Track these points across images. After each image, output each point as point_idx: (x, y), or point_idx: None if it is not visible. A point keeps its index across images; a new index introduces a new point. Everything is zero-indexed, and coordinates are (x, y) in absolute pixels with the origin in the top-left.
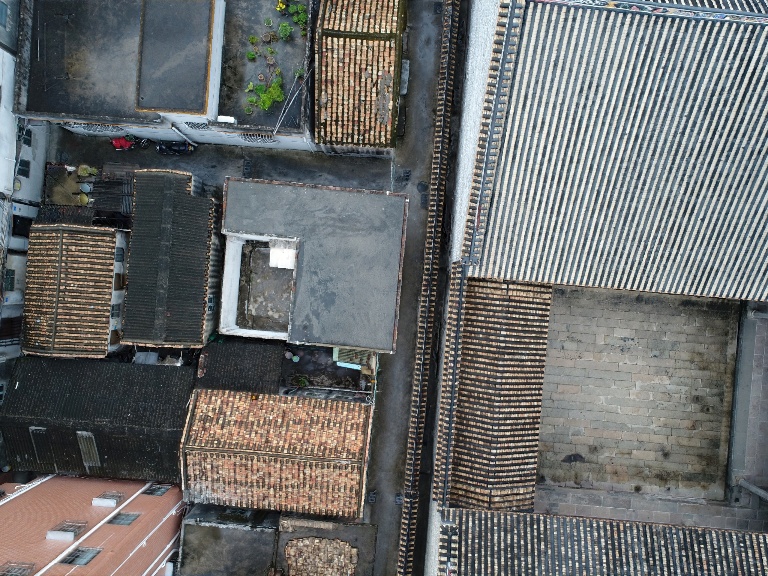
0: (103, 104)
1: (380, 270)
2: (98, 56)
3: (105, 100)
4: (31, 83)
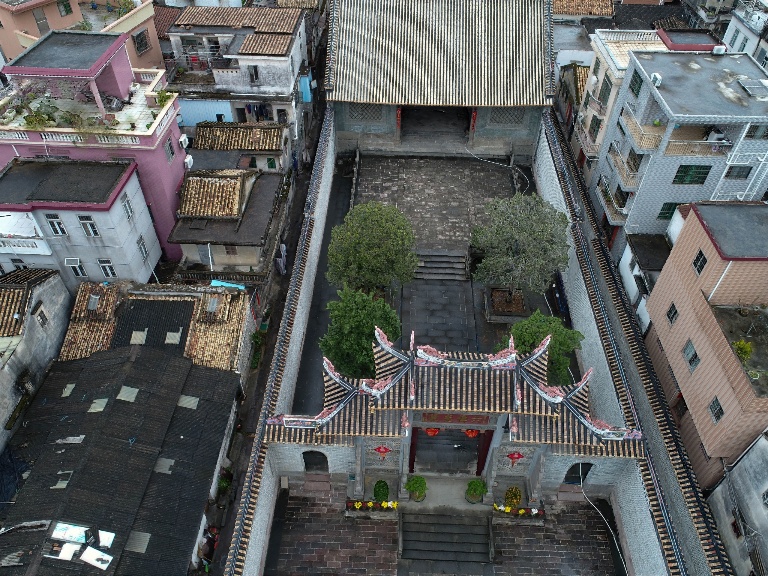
0: None
1: None
2: None
3: None
4: None
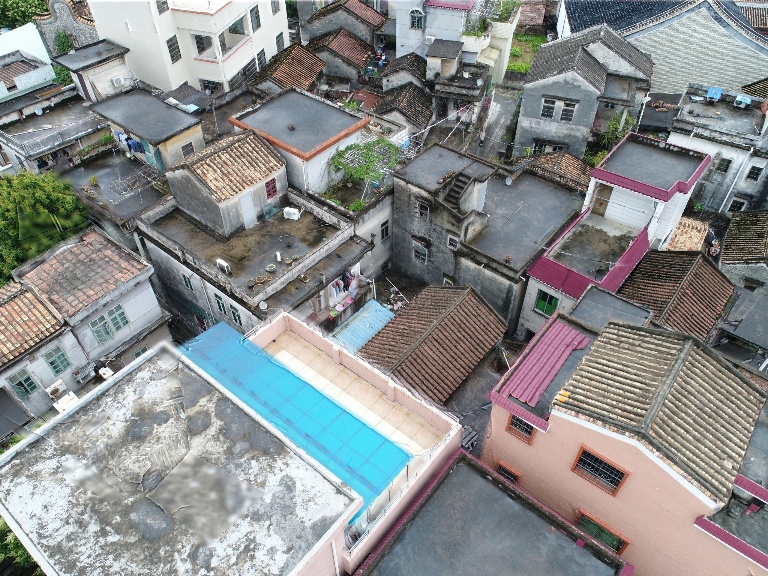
0: None
1: None
2: None
3: None
4: None
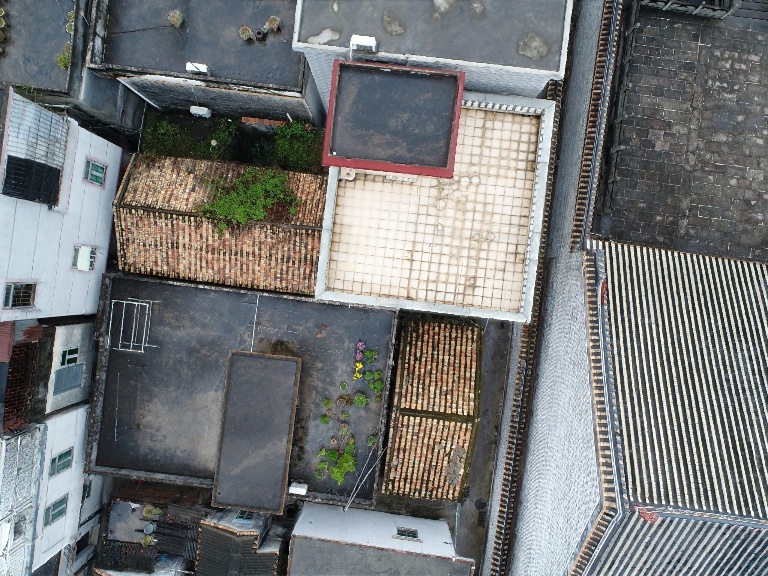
0: (173, 457)
1: None
2: (170, 409)
3: (175, 453)
4: (102, 433)
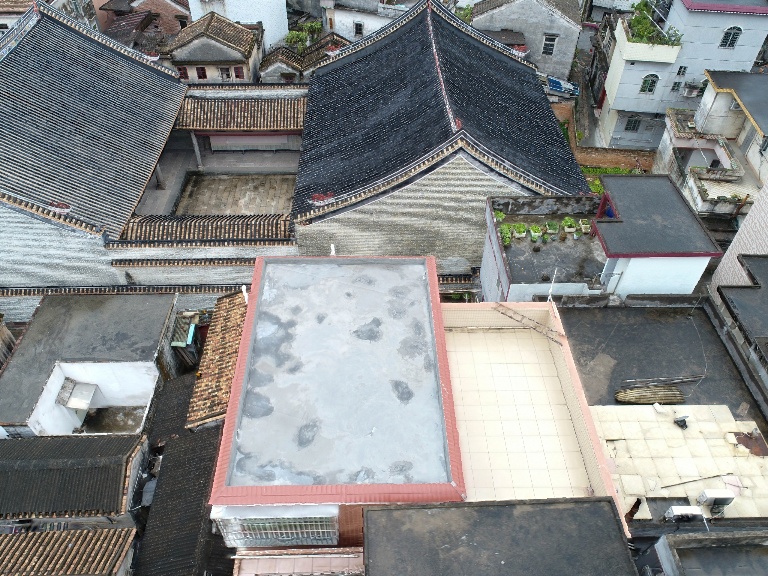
0: None
1: (104, 306)
2: None
3: None
4: None
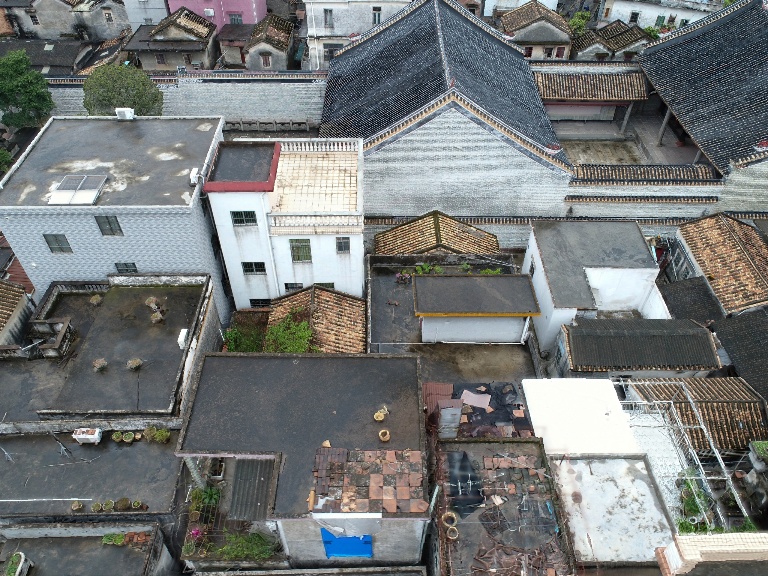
0: None
1: (585, 230)
2: None
3: None
4: None
